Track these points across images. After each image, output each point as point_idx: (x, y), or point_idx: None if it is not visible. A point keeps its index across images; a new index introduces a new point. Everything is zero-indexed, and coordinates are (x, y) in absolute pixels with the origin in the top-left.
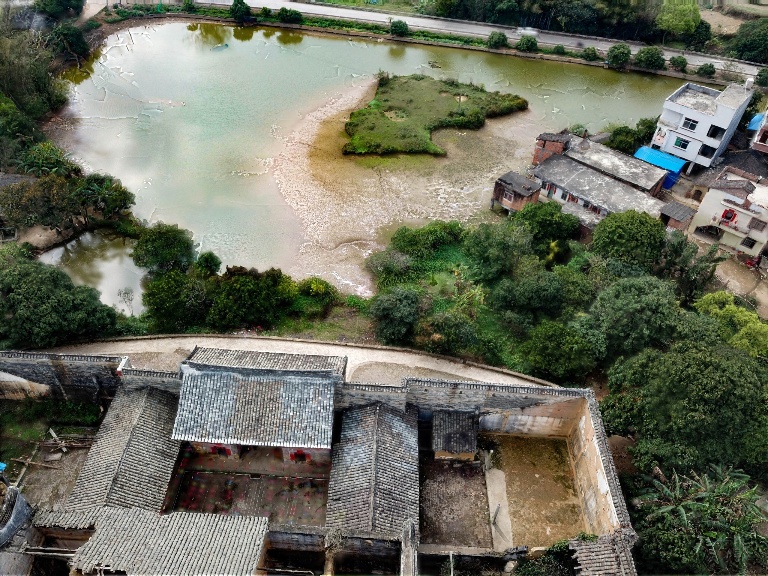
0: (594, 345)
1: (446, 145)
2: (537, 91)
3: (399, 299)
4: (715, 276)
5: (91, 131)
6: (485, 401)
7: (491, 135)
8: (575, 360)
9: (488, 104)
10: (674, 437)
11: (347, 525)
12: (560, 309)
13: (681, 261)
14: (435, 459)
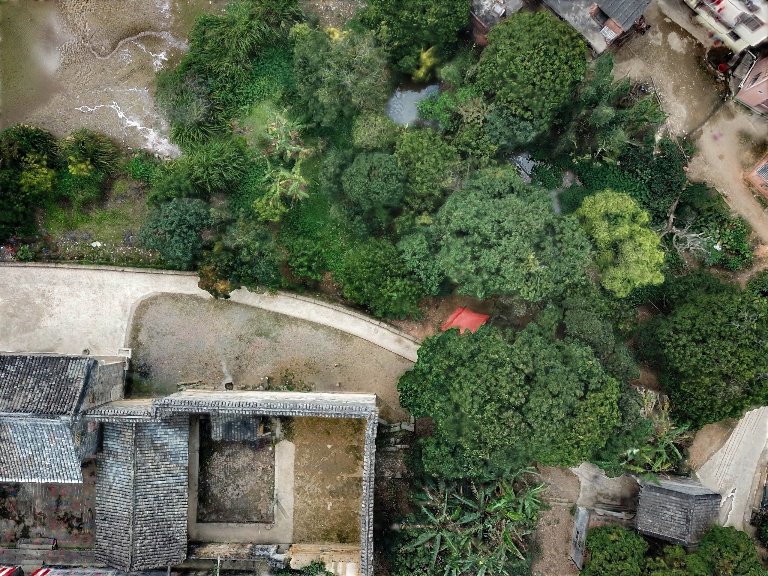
0: (424, 282)
1: None
2: None
3: (168, 231)
4: (656, 100)
5: None
6: None
7: None
8: (396, 305)
9: None
10: None
11: (112, 549)
12: (402, 203)
13: (593, 116)
14: None
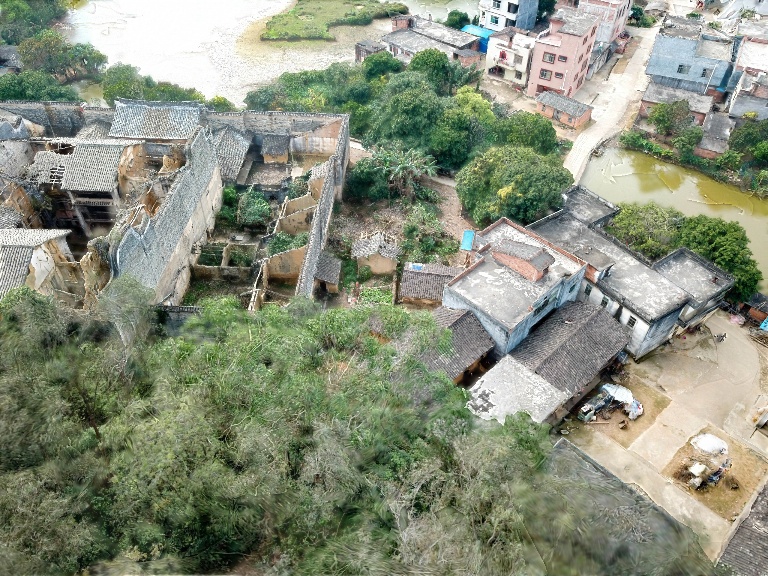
0: None
1: (338, 34)
2: (417, 0)
3: (260, 91)
4: (490, 95)
5: (83, 30)
6: (291, 126)
7: (374, 29)
8: (363, 121)
9: (377, 9)
10: (393, 138)
11: None
12: None
13: (455, 77)
14: (265, 164)
